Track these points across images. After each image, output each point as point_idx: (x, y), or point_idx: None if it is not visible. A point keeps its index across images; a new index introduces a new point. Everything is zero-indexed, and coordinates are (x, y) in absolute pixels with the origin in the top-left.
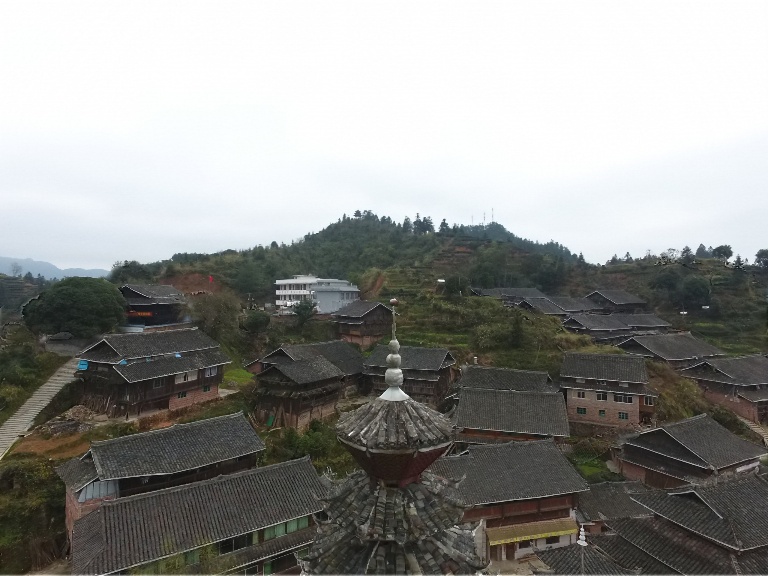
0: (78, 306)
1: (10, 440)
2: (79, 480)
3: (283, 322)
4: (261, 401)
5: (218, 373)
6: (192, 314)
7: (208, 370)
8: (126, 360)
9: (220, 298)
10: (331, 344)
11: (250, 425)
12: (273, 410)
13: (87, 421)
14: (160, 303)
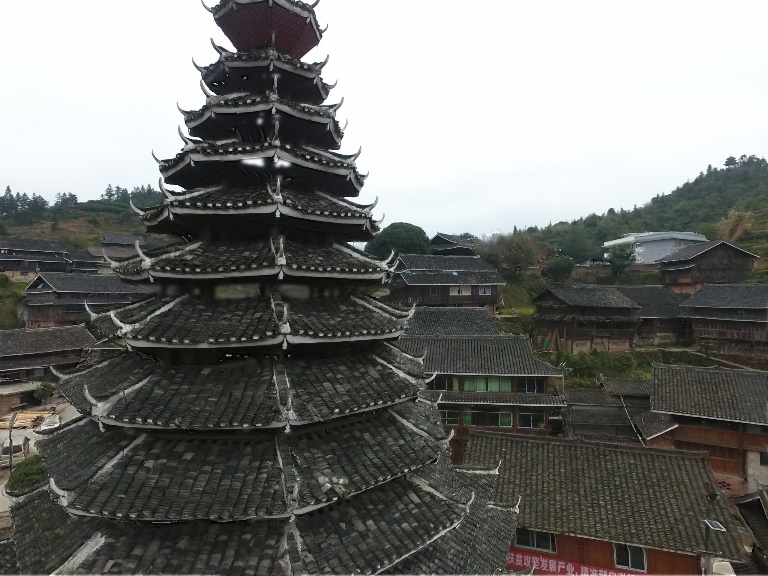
0: (394, 242)
1: None
2: None
3: (594, 273)
4: (538, 327)
5: (493, 293)
6: (485, 253)
7: (482, 289)
8: (410, 270)
9: (513, 239)
10: (643, 288)
11: None
12: (548, 335)
13: None
14: (462, 247)
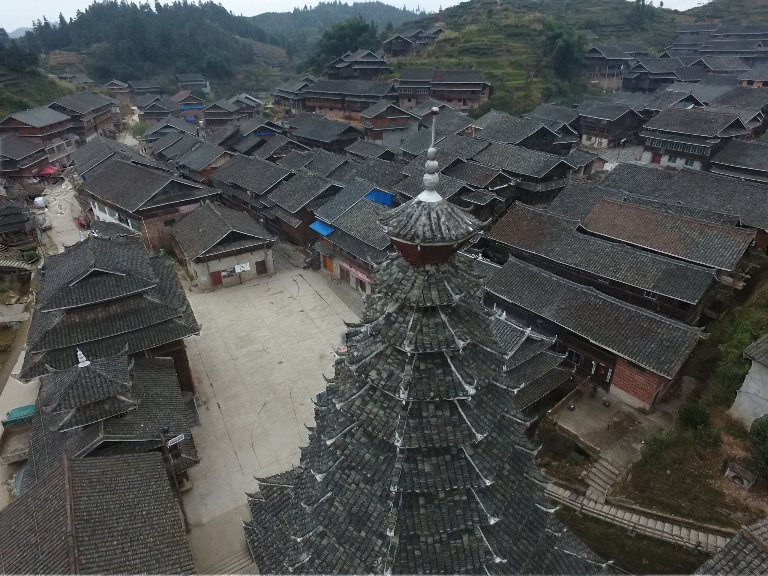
0: None
1: None
2: None
3: None
4: None
5: None
6: None
7: None
8: None
9: None
10: None
11: None
12: None
13: None
14: None
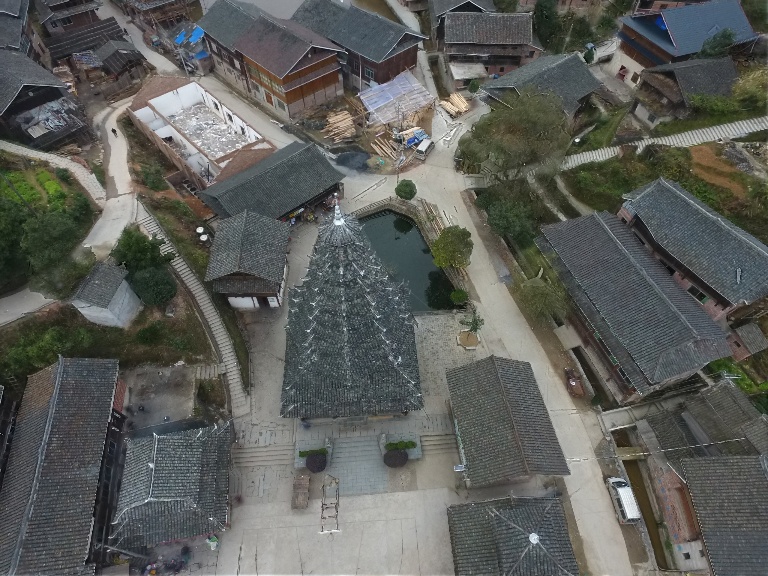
0: None
1: (714, 137)
2: (634, 194)
3: None
4: None
5: None
6: None
7: None
8: None
9: None
10: None
11: (767, 281)
12: None
13: (763, 164)
14: None
